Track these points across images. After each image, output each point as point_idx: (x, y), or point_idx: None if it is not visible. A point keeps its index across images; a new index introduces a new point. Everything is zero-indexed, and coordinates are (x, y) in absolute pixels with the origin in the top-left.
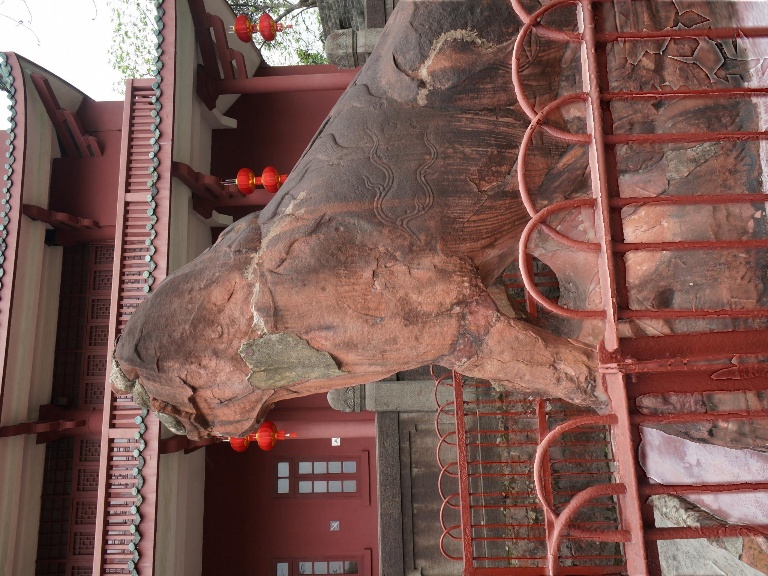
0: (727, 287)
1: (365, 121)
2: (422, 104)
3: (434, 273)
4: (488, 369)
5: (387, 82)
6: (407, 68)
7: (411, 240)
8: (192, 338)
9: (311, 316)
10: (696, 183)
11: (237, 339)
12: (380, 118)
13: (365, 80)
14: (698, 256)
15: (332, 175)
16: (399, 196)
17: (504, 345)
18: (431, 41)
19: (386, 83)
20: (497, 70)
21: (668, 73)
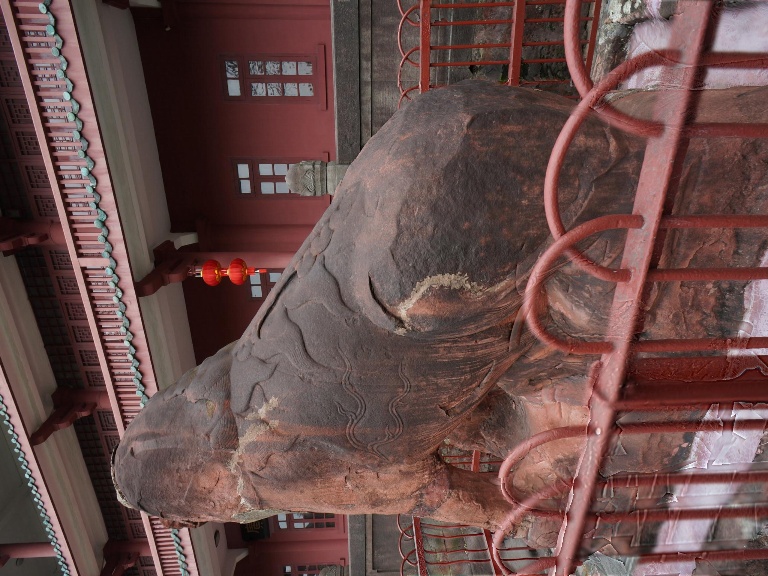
0: (636, 490)
1: (336, 337)
2: (399, 334)
3: (399, 475)
4: (437, 518)
5: (361, 300)
6: (384, 300)
7: (380, 460)
8: (188, 506)
9: (292, 504)
10: (646, 412)
11: (229, 510)
12: (353, 339)
13: (335, 271)
14: (624, 463)
15: (304, 393)
16: (371, 425)
17: (451, 513)
18: (414, 283)
19: (360, 300)
20: (483, 315)
21: (661, 314)
